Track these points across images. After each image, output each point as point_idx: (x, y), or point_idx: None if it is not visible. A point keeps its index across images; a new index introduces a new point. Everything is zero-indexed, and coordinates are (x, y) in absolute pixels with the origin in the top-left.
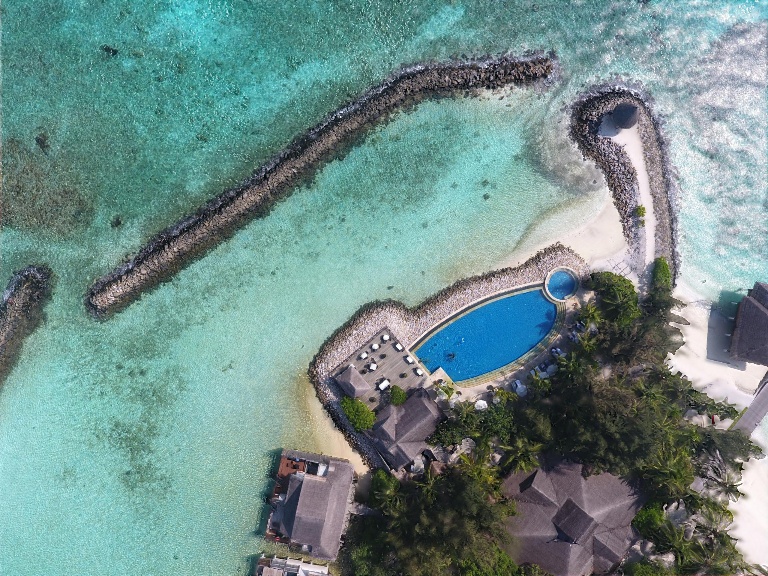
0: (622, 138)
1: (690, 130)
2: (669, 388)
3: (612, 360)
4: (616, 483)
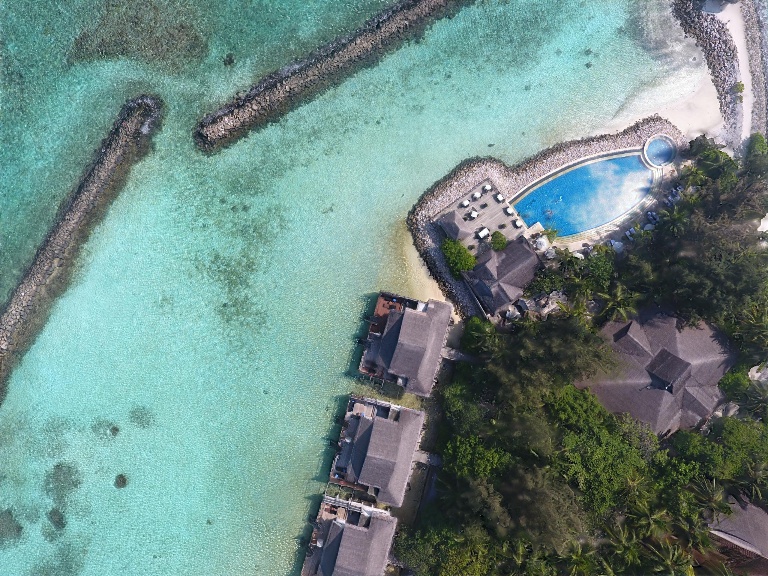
0: (725, 15)
1: None
2: (763, 253)
3: (716, 211)
4: (708, 340)
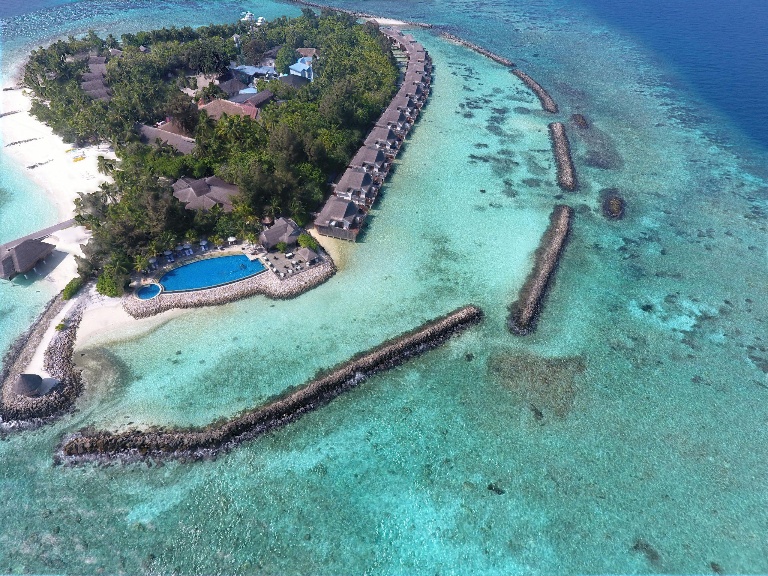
0: None
1: None
2: None
3: None
4: None
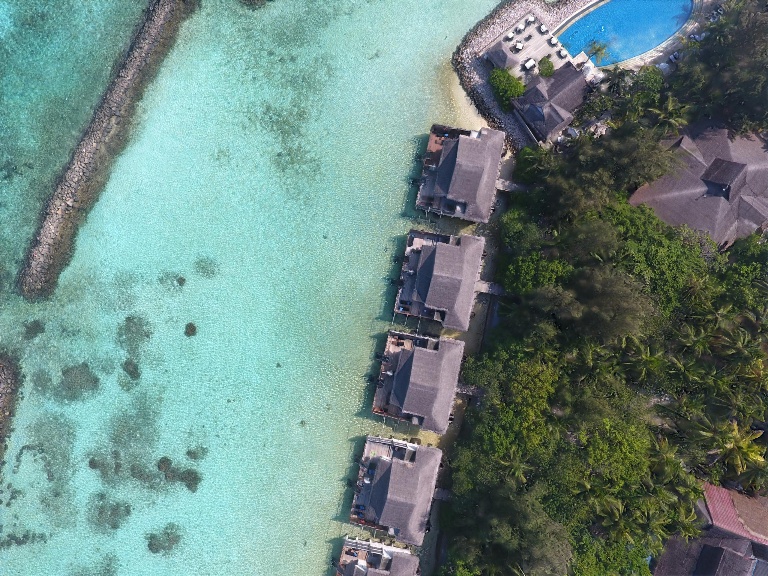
0: None
1: None
2: None
3: None
4: (759, 150)
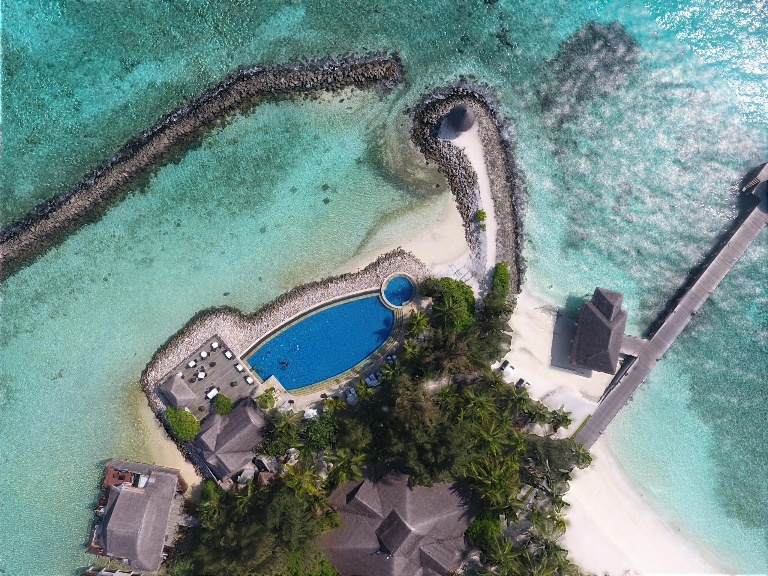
0: (462, 141)
1: (537, 133)
2: (502, 396)
3: (432, 368)
4: (445, 493)
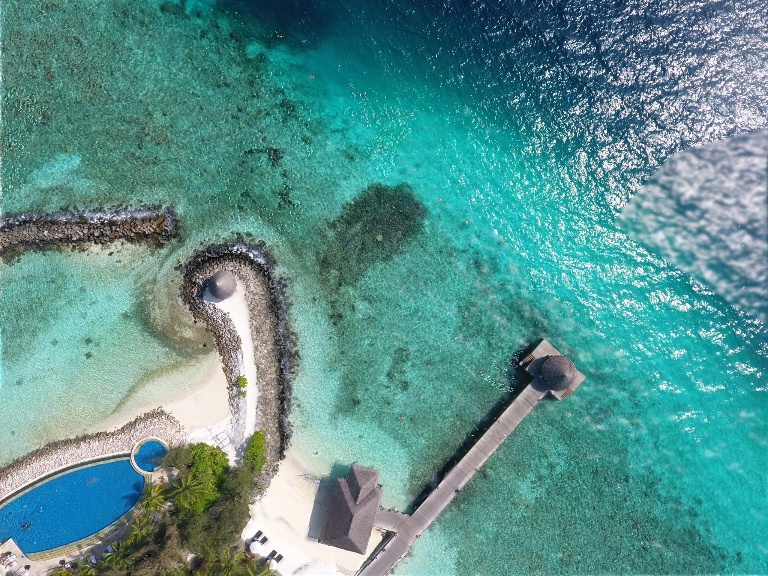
0: (227, 304)
1: (314, 294)
2: None
3: None
4: None
